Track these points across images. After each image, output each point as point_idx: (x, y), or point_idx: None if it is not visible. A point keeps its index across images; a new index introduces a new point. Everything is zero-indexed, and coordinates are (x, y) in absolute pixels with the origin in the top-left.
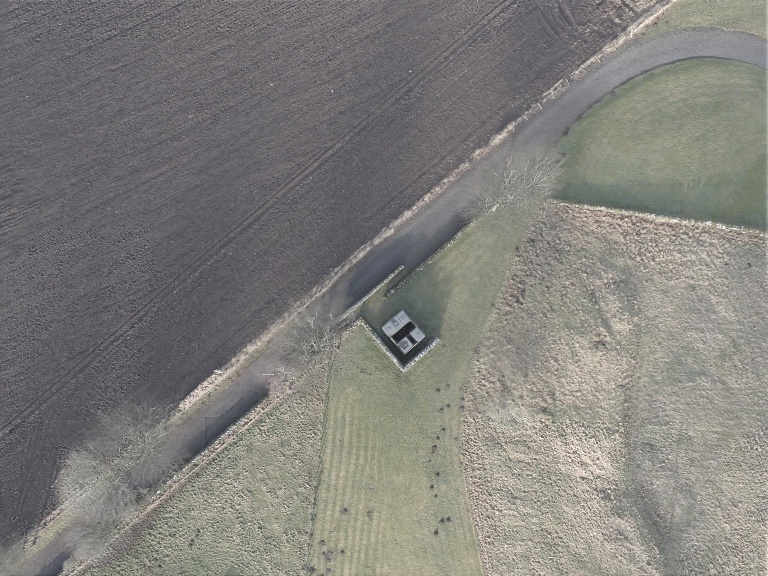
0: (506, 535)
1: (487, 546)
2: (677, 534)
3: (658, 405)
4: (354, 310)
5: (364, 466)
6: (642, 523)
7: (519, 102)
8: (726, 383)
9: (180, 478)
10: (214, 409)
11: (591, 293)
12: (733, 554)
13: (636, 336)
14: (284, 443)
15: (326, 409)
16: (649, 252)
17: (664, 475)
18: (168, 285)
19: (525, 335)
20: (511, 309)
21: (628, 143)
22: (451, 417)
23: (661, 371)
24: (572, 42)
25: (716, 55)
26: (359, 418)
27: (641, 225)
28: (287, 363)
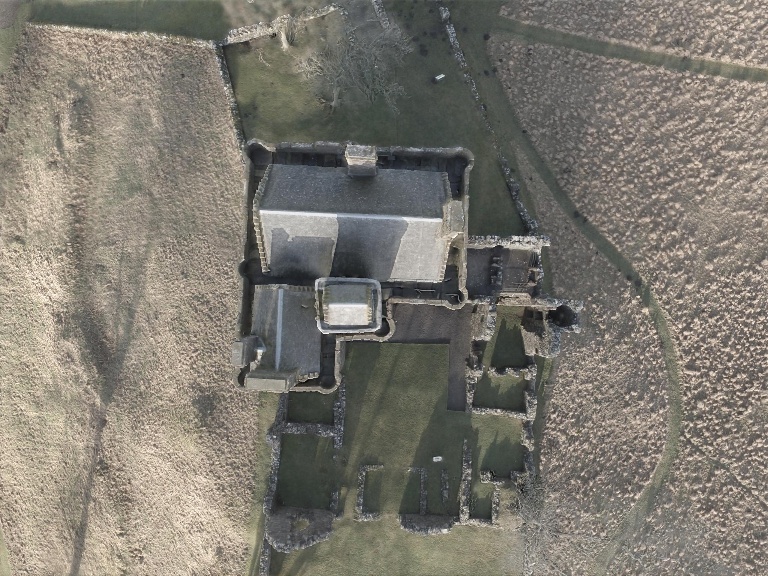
0: None
1: None
2: (121, 355)
3: (110, 226)
4: None
5: None
6: (85, 343)
7: None
8: (152, 194)
9: None
10: None
11: (56, 115)
12: (156, 368)
13: (88, 155)
14: None
15: None
16: (106, 70)
17: (109, 295)
18: None
19: (5, 164)
20: None
21: None
22: None
23: (113, 191)
24: None
25: None
26: None
27: (102, 44)
28: None
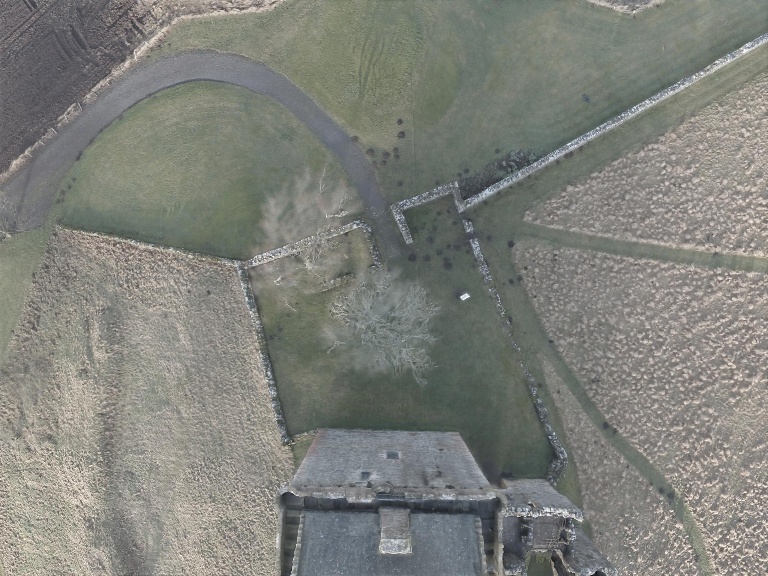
0: (27, 563)
1: (11, 573)
2: (150, 564)
3: (138, 433)
4: None
5: None
6: (115, 553)
7: (37, 127)
8: (180, 412)
9: None
10: None
11: (86, 320)
12: None
13: (117, 364)
14: None
15: None
16: (134, 279)
17: (139, 504)
18: None
19: (37, 362)
20: (28, 336)
21: (126, 168)
22: None
23: (141, 399)
24: (83, 65)
25: (211, 78)
26: None
27: (129, 251)
28: None
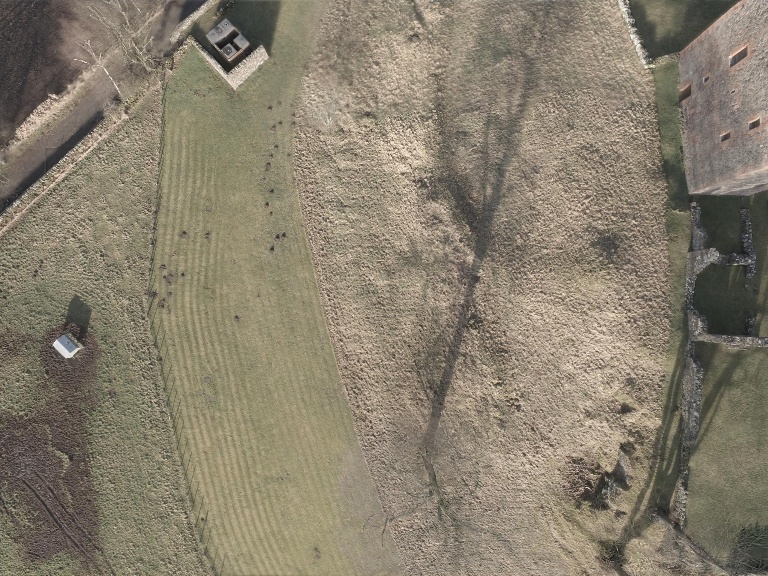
0: (338, 245)
1: (321, 259)
2: (489, 214)
3: (471, 93)
4: (185, 30)
5: (201, 188)
6: (455, 204)
7: None
8: (527, 55)
9: (21, 209)
10: (54, 140)
11: None
12: (536, 220)
13: (448, 27)
14: (123, 170)
15: (162, 133)
16: None
17: (476, 158)
18: (4, 17)
19: (350, 45)
20: (338, 23)
21: None
22: (283, 134)
23: (473, 60)
24: None
25: None
26: (195, 141)
27: None
28: (116, 77)
